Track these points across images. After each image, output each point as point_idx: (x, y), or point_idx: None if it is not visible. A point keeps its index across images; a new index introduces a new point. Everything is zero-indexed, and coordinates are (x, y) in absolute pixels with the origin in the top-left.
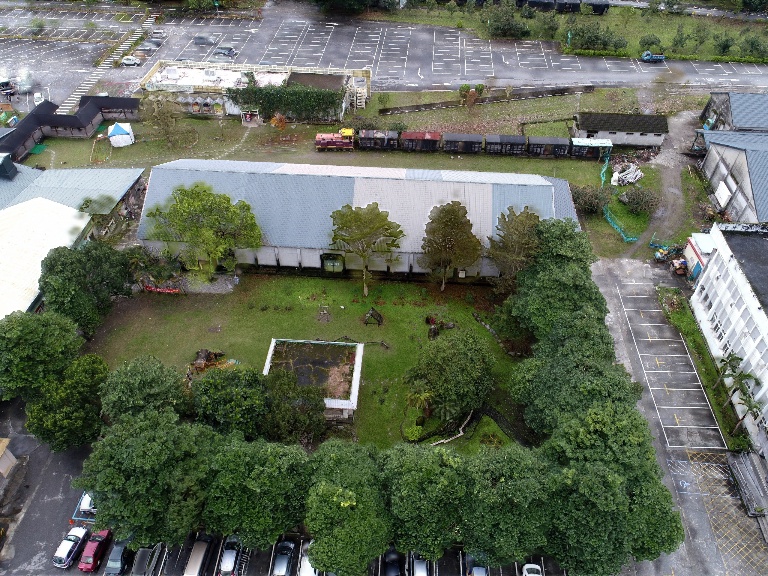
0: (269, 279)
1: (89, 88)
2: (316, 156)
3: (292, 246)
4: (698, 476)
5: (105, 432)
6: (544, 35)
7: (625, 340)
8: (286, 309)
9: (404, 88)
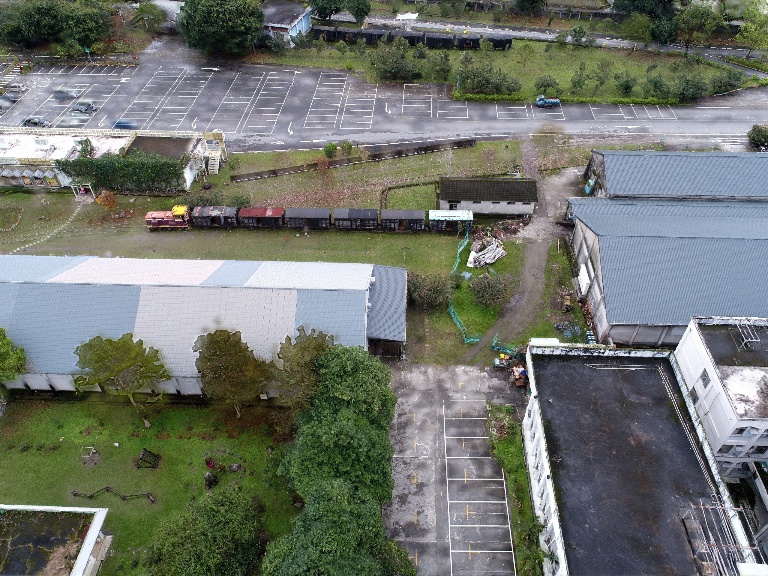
0: (44, 407)
1: None
2: (147, 237)
3: (60, 372)
4: None
5: None
6: (438, 76)
7: (436, 481)
8: (51, 449)
9: (268, 147)
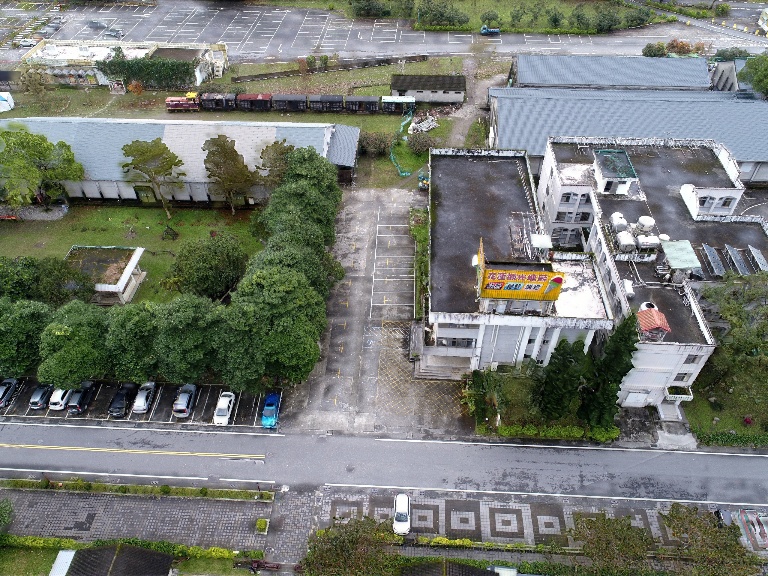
0: (95, 209)
1: None
2: (166, 116)
3: (108, 180)
4: (383, 337)
5: None
6: (404, 14)
7: (369, 247)
8: (102, 230)
9: (261, 61)
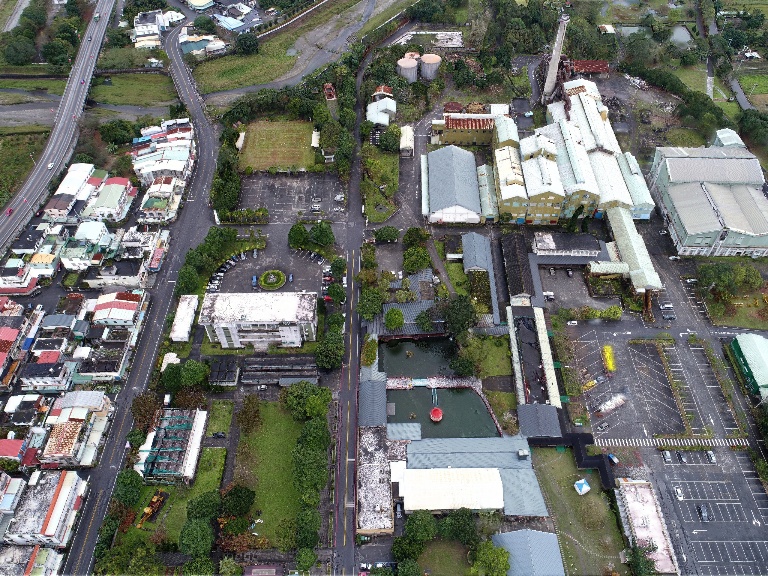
0: None
1: (627, 445)
2: None
3: None
4: None
5: (390, 569)
6: None
7: None
8: None
9: None
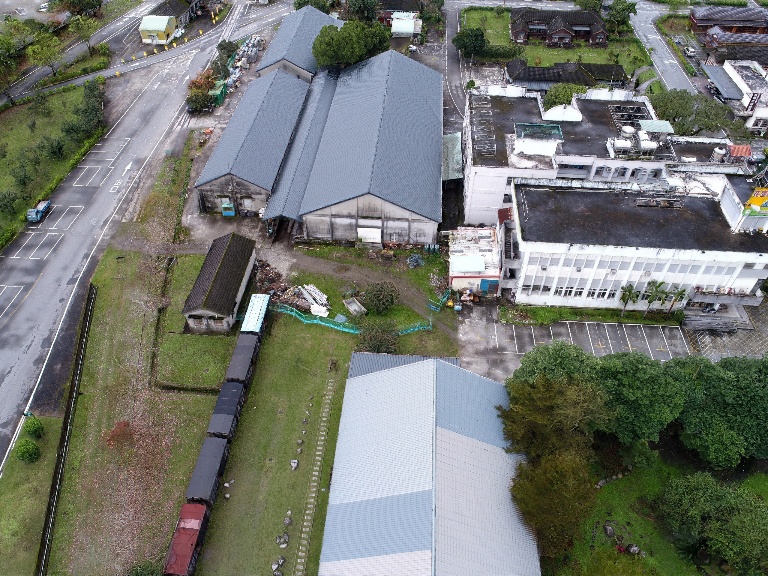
0: None
1: None
2: None
3: None
4: (714, 351)
5: None
6: None
7: None
8: None
9: None
